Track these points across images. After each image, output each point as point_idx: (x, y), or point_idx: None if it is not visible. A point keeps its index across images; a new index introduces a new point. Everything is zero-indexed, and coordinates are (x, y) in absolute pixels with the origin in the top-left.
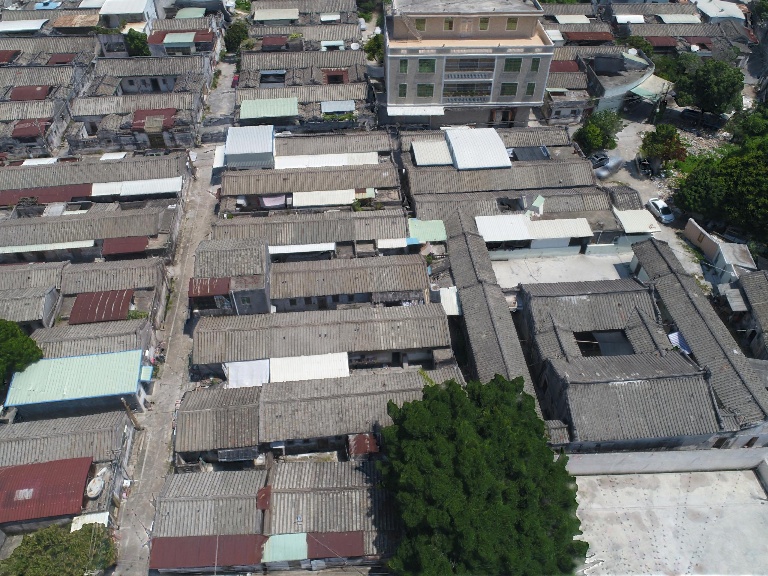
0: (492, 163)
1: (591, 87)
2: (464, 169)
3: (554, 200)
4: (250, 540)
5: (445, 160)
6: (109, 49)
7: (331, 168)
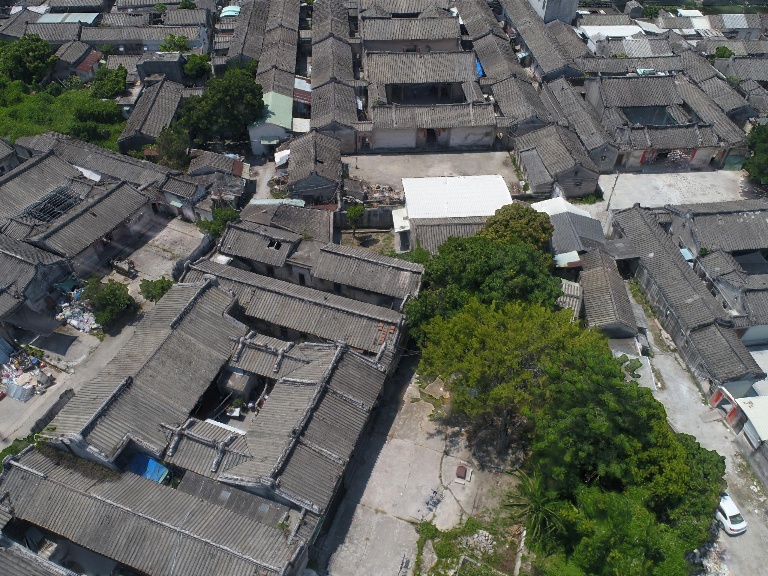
0: None
1: None
2: None
3: None
4: None
5: None
6: None
7: None
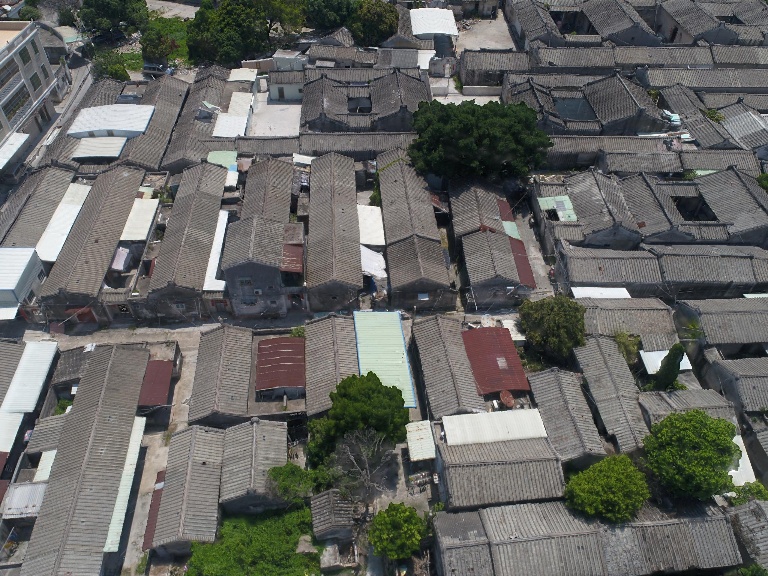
0: (146, 114)
1: None
2: (145, 130)
3: (208, 98)
4: (512, 240)
5: (119, 141)
6: None
7: (90, 210)
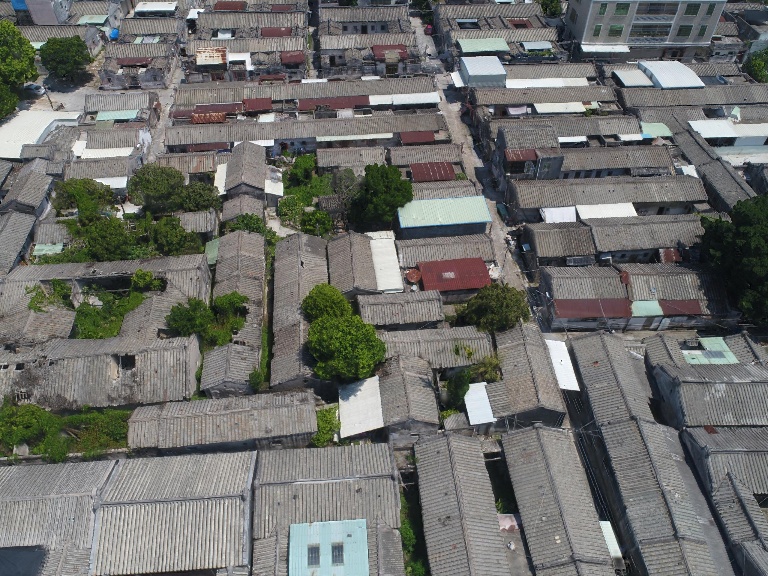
0: (689, 84)
1: (742, 34)
2: (667, 88)
3: (748, 110)
4: (622, 302)
5: (647, 83)
6: (324, 0)
7: None
